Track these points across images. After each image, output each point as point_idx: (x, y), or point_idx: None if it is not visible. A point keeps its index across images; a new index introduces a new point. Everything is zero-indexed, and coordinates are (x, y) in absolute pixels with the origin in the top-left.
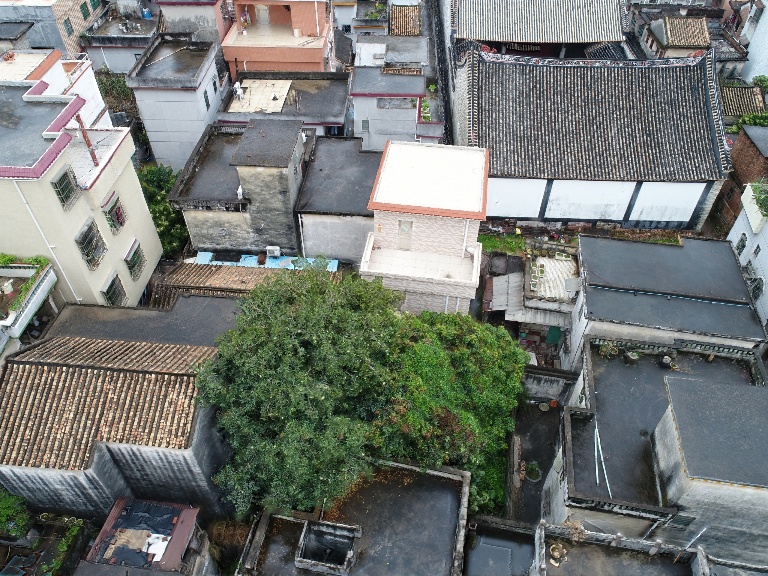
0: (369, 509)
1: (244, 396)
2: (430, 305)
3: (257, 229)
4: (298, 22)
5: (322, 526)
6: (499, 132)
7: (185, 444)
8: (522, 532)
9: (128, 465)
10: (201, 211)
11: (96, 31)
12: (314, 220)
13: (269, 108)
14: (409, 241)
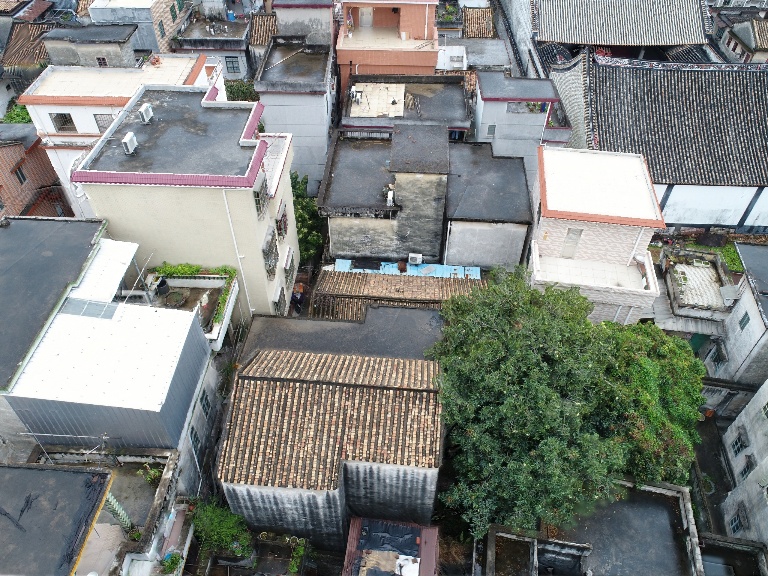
0: (587, 526)
1: (485, 412)
2: (599, 314)
3: (402, 236)
4: (406, 25)
5: (549, 544)
6: (617, 137)
7: (437, 463)
8: (739, 549)
9: (357, 483)
10: (348, 218)
11: (183, 33)
12: (463, 227)
13: (391, 112)
14: (574, 249)
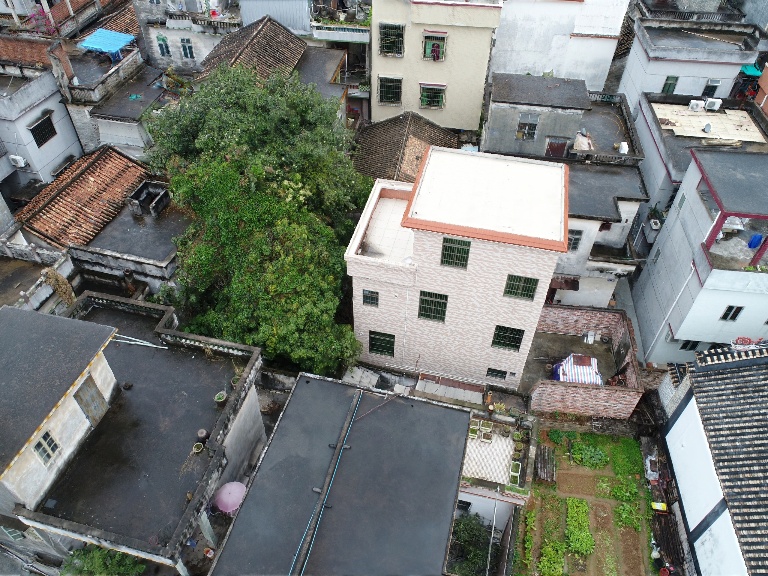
0: (173, 223)
1: None
2: None
3: None
4: None
5: None
6: None
7: (192, 81)
8: None
9: None
10: None
11: None
12: None
13: (680, 127)
14: None
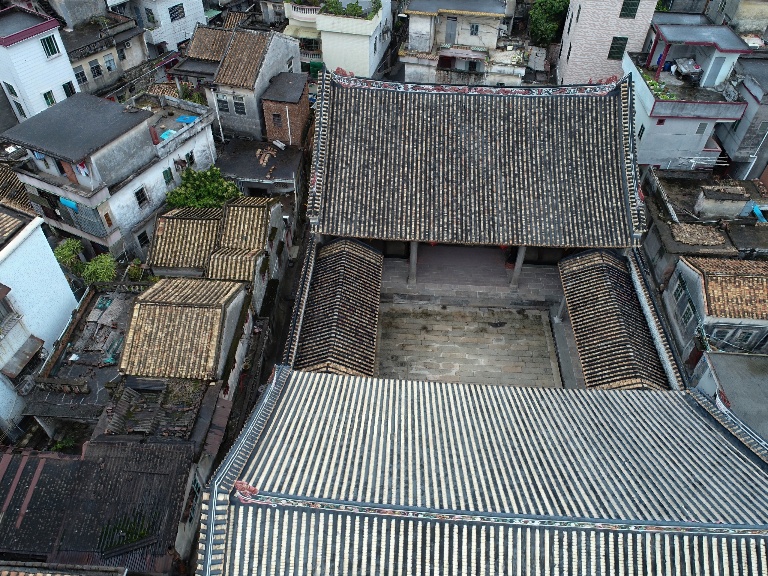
0: None
1: None
2: None
3: None
4: None
5: None
6: None
7: None
8: None
9: None
10: None
11: None
12: None
13: None
14: None
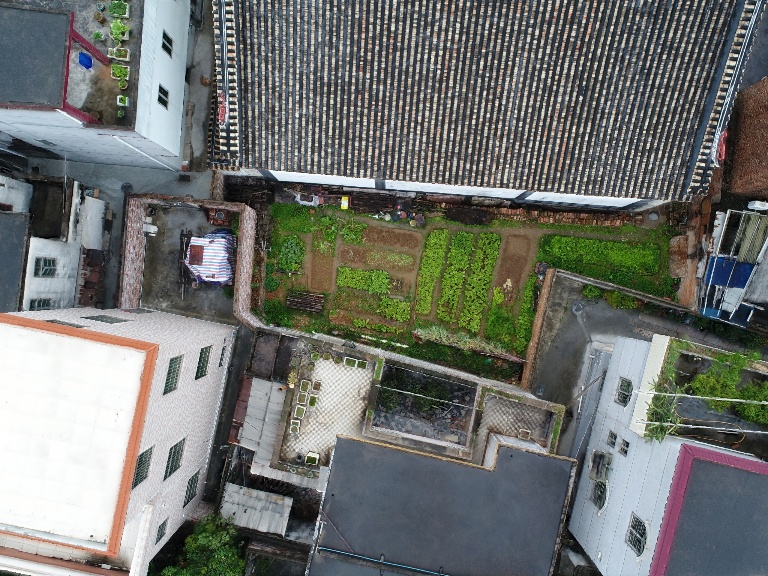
0: None
1: None
2: None
3: None
4: None
5: None
6: (286, 74)
7: None
8: None
9: None
10: None
11: None
12: None
13: None
14: None
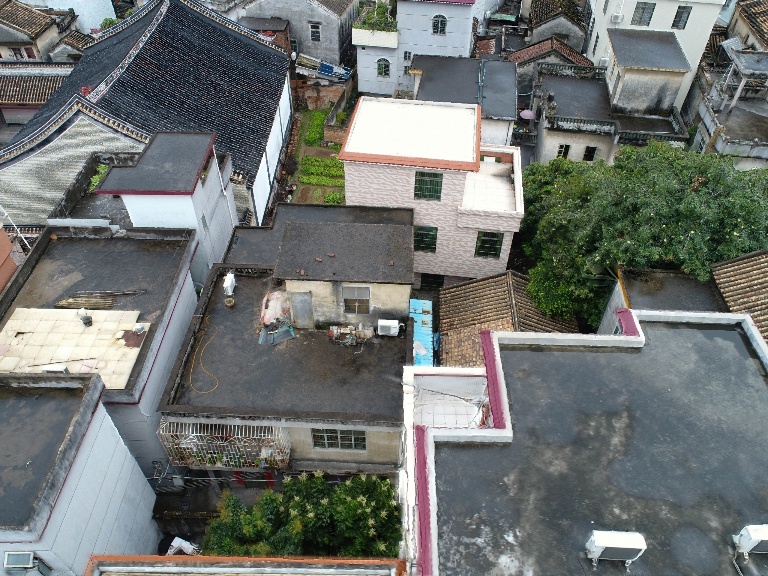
0: None
1: None
2: None
3: None
4: None
5: None
6: None
7: None
8: None
9: None
10: None
11: None
12: None
13: (121, 328)
14: None
